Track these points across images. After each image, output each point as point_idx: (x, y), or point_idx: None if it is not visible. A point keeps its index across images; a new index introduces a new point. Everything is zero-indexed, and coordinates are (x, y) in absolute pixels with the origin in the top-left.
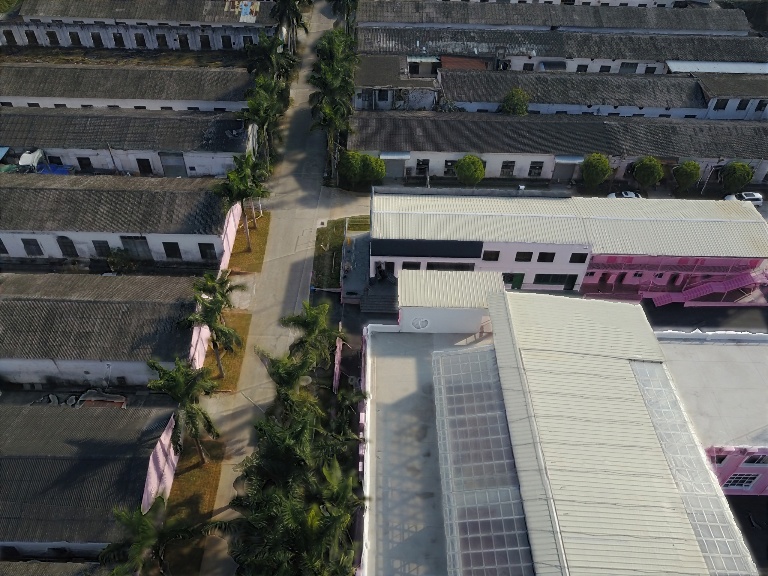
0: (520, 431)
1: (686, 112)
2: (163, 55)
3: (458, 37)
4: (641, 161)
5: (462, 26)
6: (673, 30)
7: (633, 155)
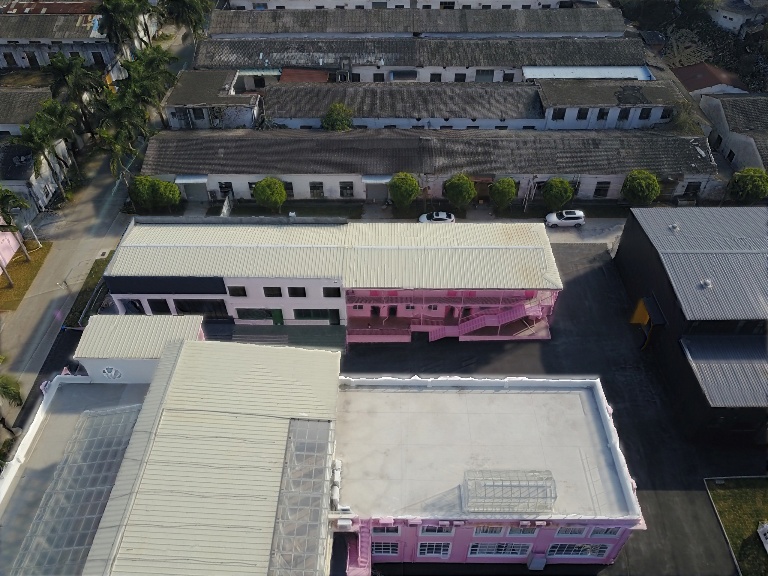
0: (114, 510)
1: (523, 123)
2: (10, 74)
3: (304, 48)
4: (450, 179)
5: (319, 35)
6: (543, 33)
7: (445, 173)
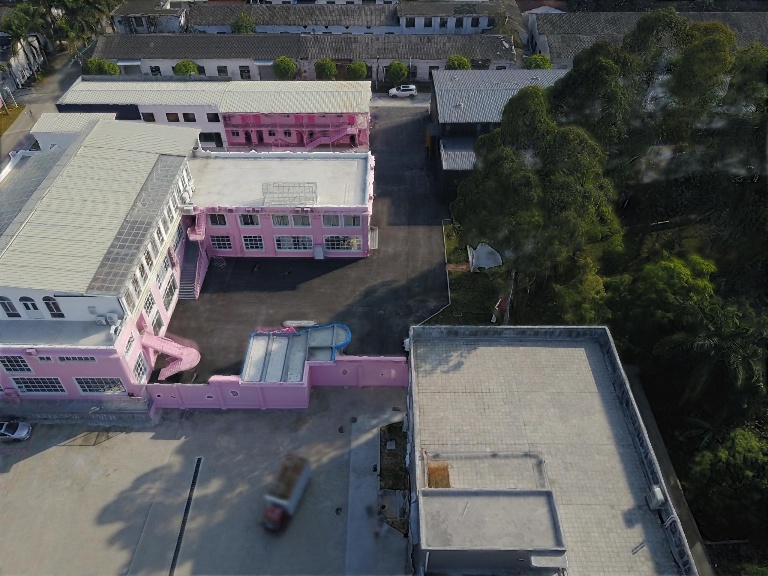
0: (46, 183)
1: (385, 30)
2: None
3: None
4: None
5: None
6: None
7: (316, 58)
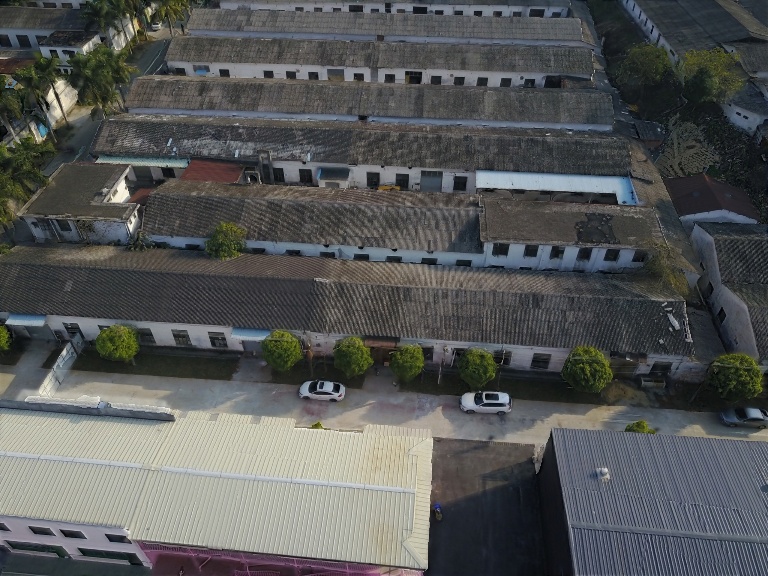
0: None
1: (457, 256)
2: None
3: (221, 134)
4: (338, 344)
5: (250, 114)
6: (513, 122)
7: (336, 332)
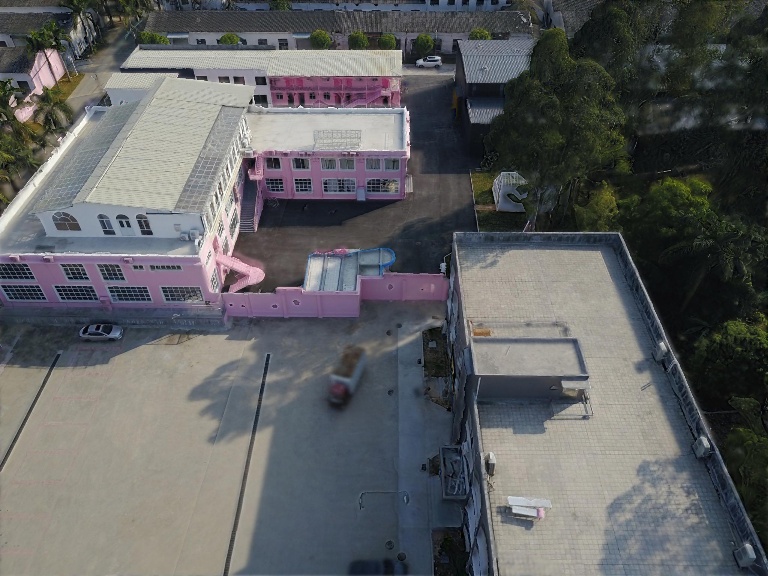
0: (127, 127)
1: (411, 7)
2: None
3: None
4: (351, 34)
5: None
6: None
7: (349, 31)
